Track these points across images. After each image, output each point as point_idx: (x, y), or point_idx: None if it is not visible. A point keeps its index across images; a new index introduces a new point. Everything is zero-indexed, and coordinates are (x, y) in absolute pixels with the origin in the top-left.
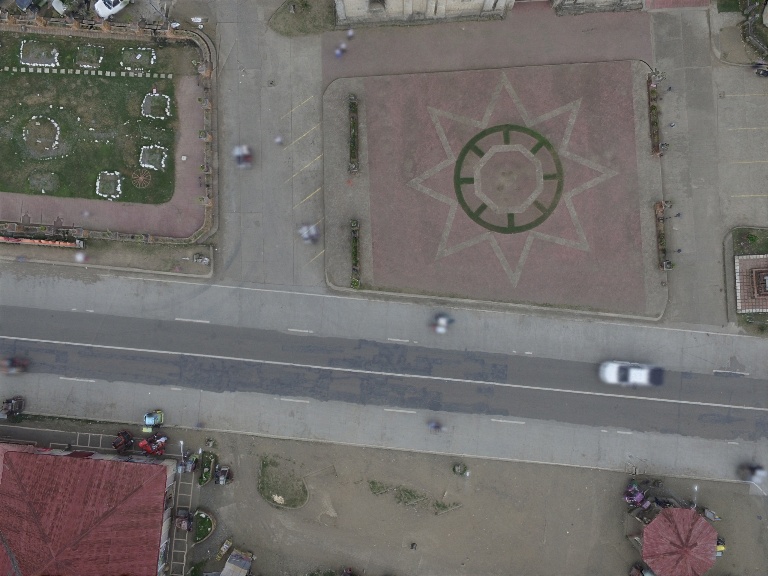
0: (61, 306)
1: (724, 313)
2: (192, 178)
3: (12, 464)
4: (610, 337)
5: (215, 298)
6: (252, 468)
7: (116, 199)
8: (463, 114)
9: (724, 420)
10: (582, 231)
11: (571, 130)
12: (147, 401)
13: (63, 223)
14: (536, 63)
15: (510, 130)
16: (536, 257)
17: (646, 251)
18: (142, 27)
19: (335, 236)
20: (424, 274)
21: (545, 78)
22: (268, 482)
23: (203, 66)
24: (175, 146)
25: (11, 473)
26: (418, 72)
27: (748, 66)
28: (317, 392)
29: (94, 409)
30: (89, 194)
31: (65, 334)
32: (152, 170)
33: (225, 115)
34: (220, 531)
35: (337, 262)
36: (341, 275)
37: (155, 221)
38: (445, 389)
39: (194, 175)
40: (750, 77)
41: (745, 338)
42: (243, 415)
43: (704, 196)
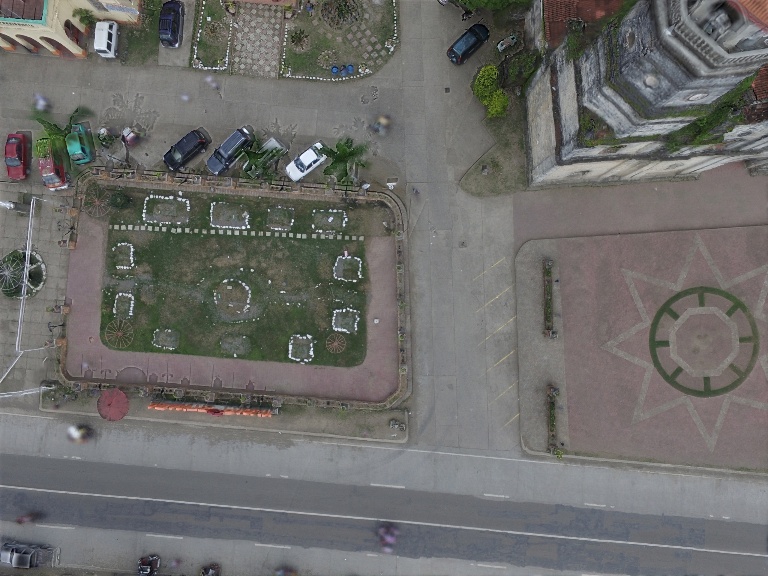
0: (255, 472)
1: None
2: (384, 341)
3: None
4: None
5: (410, 463)
6: None
7: (308, 363)
8: (657, 276)
9: None
10: None
11: (766, 292)
12: (343, 567)
13: (255, 387)
14: (730, 224)
15: (705, 292)
16: (733, 421)
17: None
18: (332, 188)
19: (530, 400)
20: (620, 438)
21: (740, 239)
22: None
23: None
24: (367, 308)
25: None
26: (612, 234)
27: None
28: (514, 558)
29: (290, 575)
30: (281, 357)
31: (260, 500)
32: (345, 333)
33: (416, 277)
34: None
35: (533, 426)
36: (537, 440)
37: (347, 384)
38: (642, 554)
39: (386, 338)
40: None
41: None
42: None
43: None
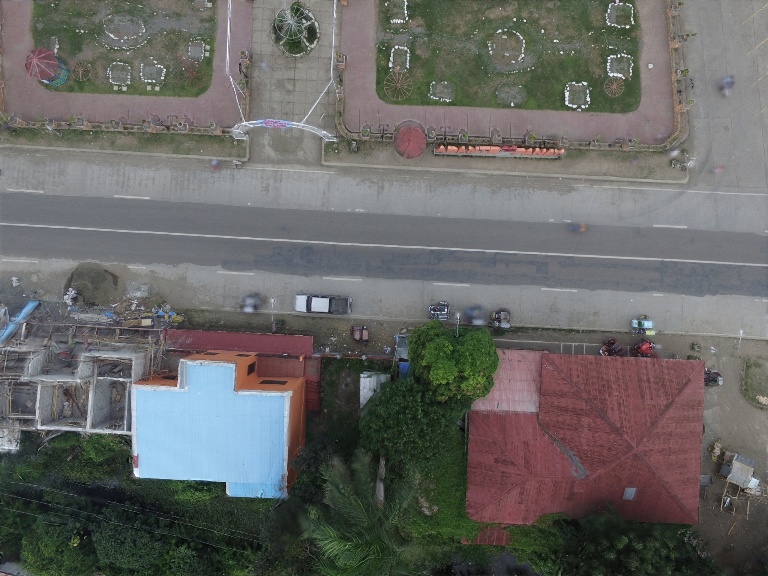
0: (538, 218)
1: None
2: (658, 86)
3: (556, 364)
4: None
5: (691, 203)
6: (734, 371)
7: (584, 109)
8: None
9: None
10: None
11: None
12: (630, 308)
13: None
14: None
15: None
16: None
17: None
18: None
19: None
20: None
21: None
22: (752, 383)
23: None
24: (639, 55)
25: (556, 373)
26: None
27: None
28: None
29: (578, 318)
30: (557, 106)
31: (544, 245)
32: None
33: (687, 22)
34: (706, 434)
35: None
36: None
37: (623, 130)
38: None
39: (660, 83)
40: None
41: None
42: (726, 318)
43: None
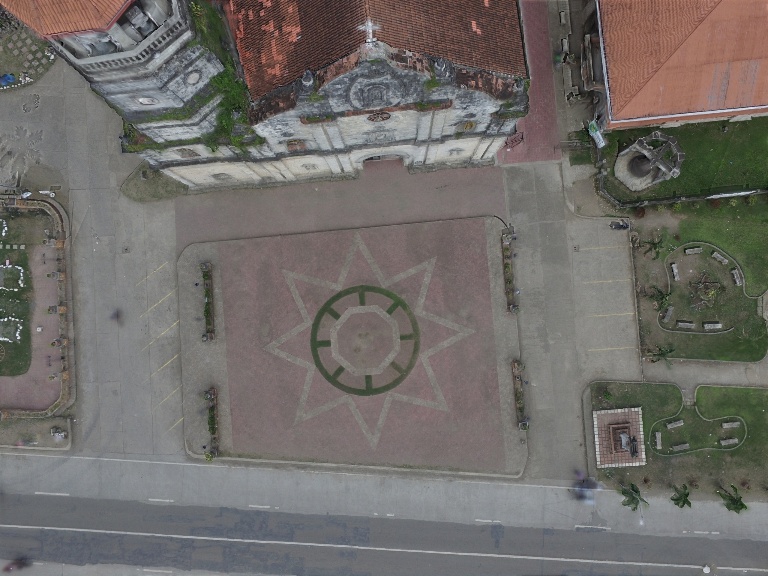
0: None
1: (584, 468)
2: (49, 348)
3: None
4: (471, 496)
5: (74, 470)
6: None
7: None
8: (318, 276)
9: (587, 575)
10: (440, 391)
11: (427, 289)
12: None
13: None
14: (390, 222)
15: (366, 291)
16: (395, 418)
17: (504, 409)
18: None
19: (193, 404)
20: (283, 439)
21: (399, 237)
22: None
23: (51, 241)
24: (30, 317)
25: None
26: (272, 235)
27: (602, 219)
28: (180, 562)
29: None
30: None
31: None
32: (7, 342)
33: (80, 284)
34: None
35: (196, 430)
36: (200, 443)
37: (13, 393)
38: (308, 554)
39: (50, 345)
40: (604, 230)
41: (606, 492)
42: None
43: (561, 351)
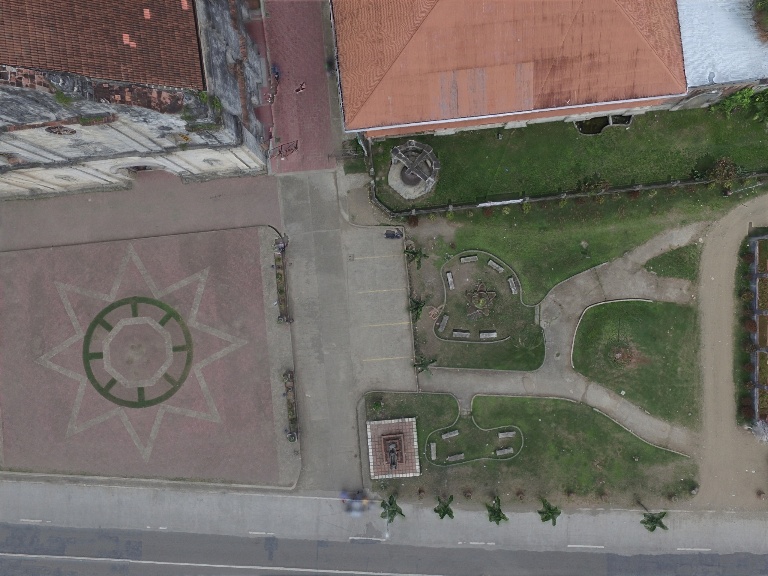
0: None
1: (359, 479)
2: None
3: None
4: (245, 508)
5: None
6: None
7: None
8: (90, 288)
9: None
10: (213, 402)
11: (199, 300)
12: None
13: None
14: (164, 232)
15: (138, 302)
16: (167, 431)
17: (278, 420)
18: None
19: None
20: (55, 452)
21: (172, 248)
22: None
23: None
24: None
25: None
26: (44, 246)
27: (376, 228)
28: None
29: None
30: None
31: None
32: None
33: None
34: None
35: None
36: None
37: None
38: (80, 568)
39: None
40: (379, 239)
41: None
42: None
43: (336, 361)
